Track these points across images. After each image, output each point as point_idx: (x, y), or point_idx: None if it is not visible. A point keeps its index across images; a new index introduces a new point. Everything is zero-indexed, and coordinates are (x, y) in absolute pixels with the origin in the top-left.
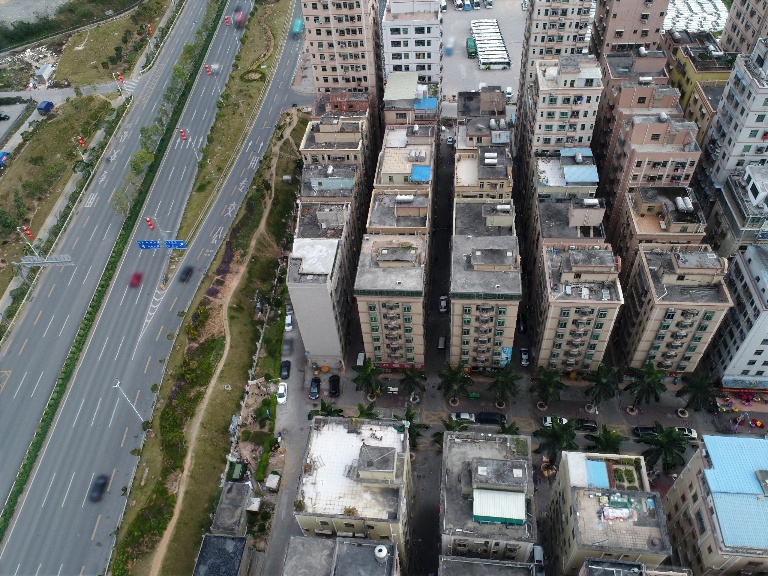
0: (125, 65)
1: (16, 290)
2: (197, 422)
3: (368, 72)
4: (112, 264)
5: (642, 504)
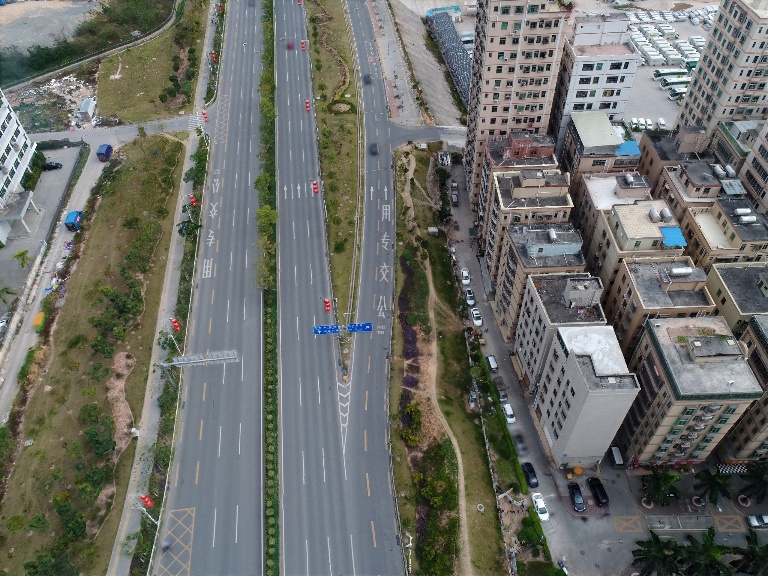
0: (183, 97)
1: (165, 397)
2: (467, 561)
3: (544, 112)
4: (271, 352)
5: None
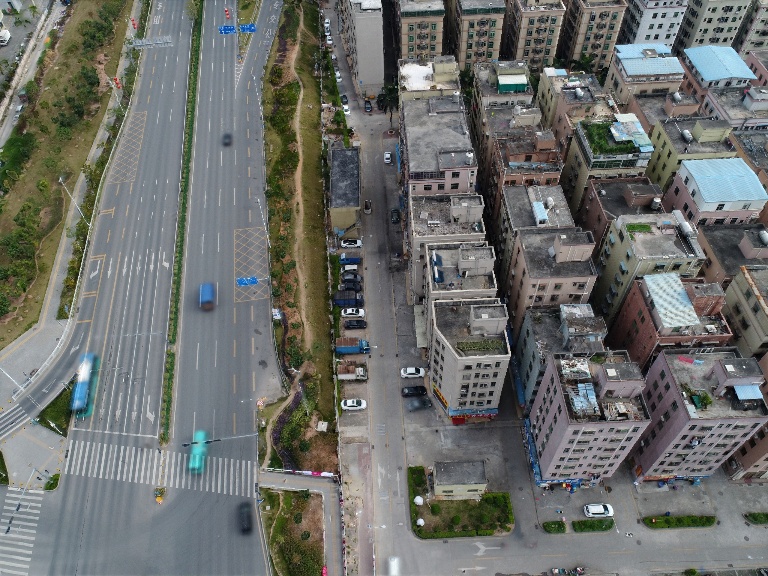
0: None
1: (129, 67)
2: (297, 121)
3: None
4: (195, 51)
5: (586, 81)
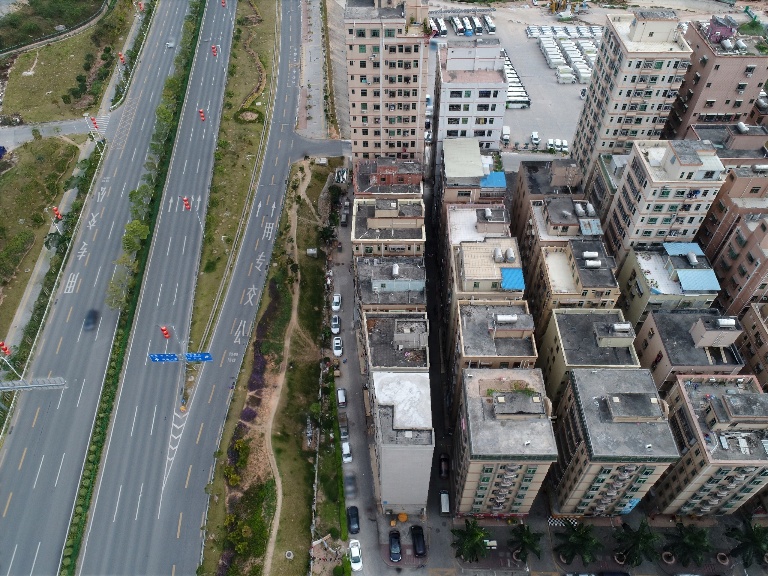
0: (90, 98)
1: None
2: None
3: (417, 137)
4: (113, 377)
5: None
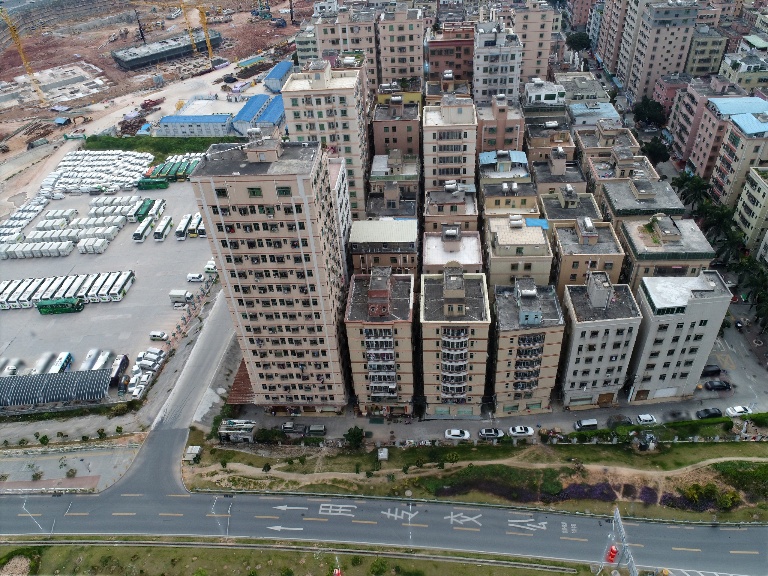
0: None
1: None
2: None
3: (340, 259)
4: None
5: None
